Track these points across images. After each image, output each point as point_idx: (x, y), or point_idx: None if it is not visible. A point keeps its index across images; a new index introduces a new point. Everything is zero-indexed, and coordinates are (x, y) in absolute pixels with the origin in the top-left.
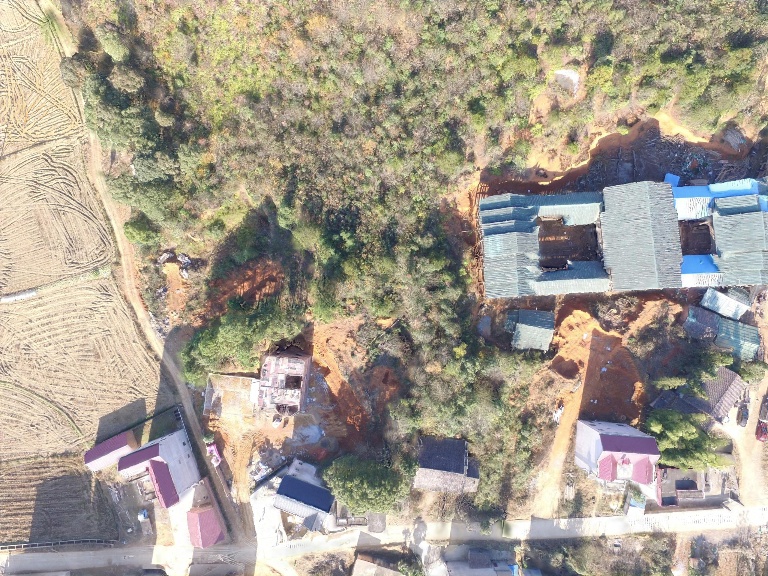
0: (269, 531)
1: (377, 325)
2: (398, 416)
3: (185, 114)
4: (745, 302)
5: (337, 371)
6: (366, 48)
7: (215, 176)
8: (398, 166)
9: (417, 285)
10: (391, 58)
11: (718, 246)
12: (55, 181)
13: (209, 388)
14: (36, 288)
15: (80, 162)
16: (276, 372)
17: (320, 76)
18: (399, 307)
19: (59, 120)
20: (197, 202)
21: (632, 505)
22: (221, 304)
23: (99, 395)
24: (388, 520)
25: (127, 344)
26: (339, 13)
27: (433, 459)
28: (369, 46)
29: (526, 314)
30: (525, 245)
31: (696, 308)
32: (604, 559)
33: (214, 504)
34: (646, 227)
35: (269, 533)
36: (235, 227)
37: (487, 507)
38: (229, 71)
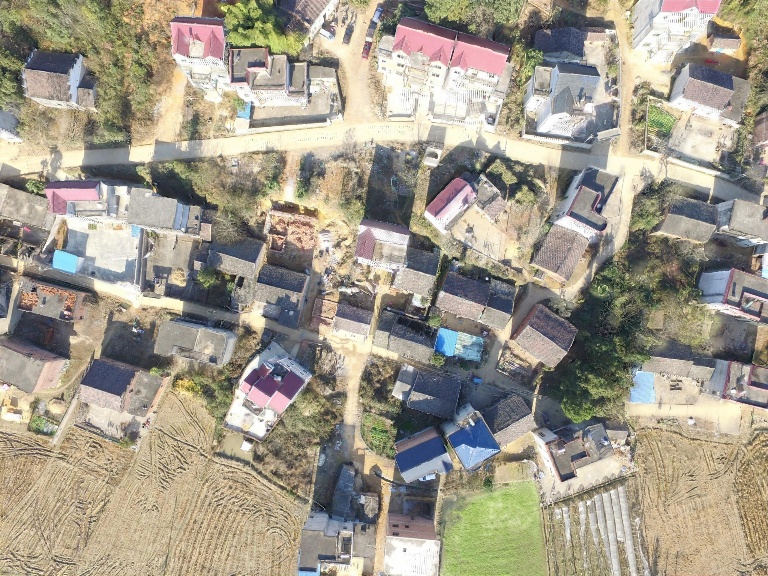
0: None
1: None
2: None
3: None
4: None
5: None
6: None
7: None
8: None
9: None
10: None
11: None
12: None
13: None
14: None
15: None
16: None
17: None
18: None
19: None
20: None
21: (237, 116)
22: None
23: None
24: (27, 151)
25: None
26: None
27: (43, 65)
28: None
29: None
30: None
31: None
32: (222, 179)
33: None
34: None
35: None
36: None
37: (106, 124)
38: None
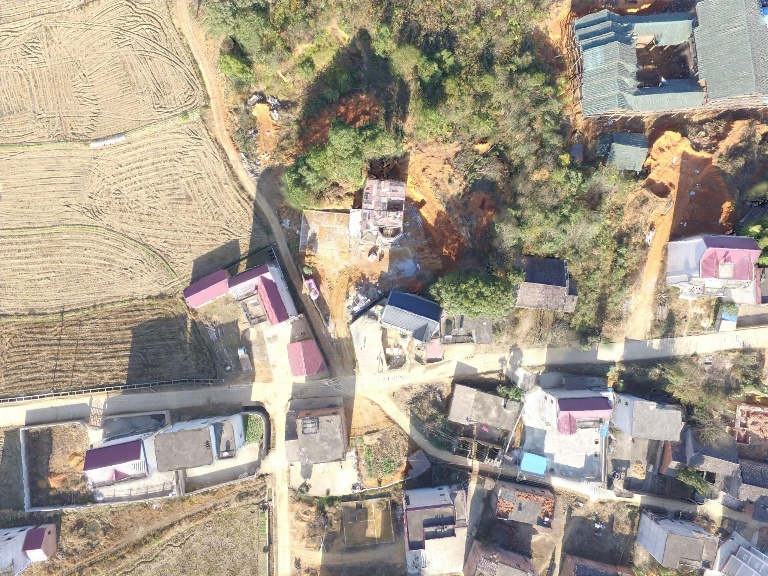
0: (371, 359)
1: (474, 151)
2: (504, 227)
3: None
4: None
5: (433, 201)
6: None
7: (311, 5)
8: None
9: (518, 101)
10: None
11: None
12: (140, 27)
13: (304, 224)
14: (125, 133)
15: (165, 8)
16: (378, 195)
17: None
18: (495, 132)
19: None
20: (292, 34)
21: (724, 319)
22: (313, 143)
23: (192, 237)
24: (484, 349)
25: (219, 187)
26: None
27: (535, 275)
28: None
29: (620, 136)
30: (625, 55)
31: None
32: (696, 377)
33: (313, 338)
34: (742, 34)
35: (371, 360)
36: (325, 67)
37: (584, 327)
38: None
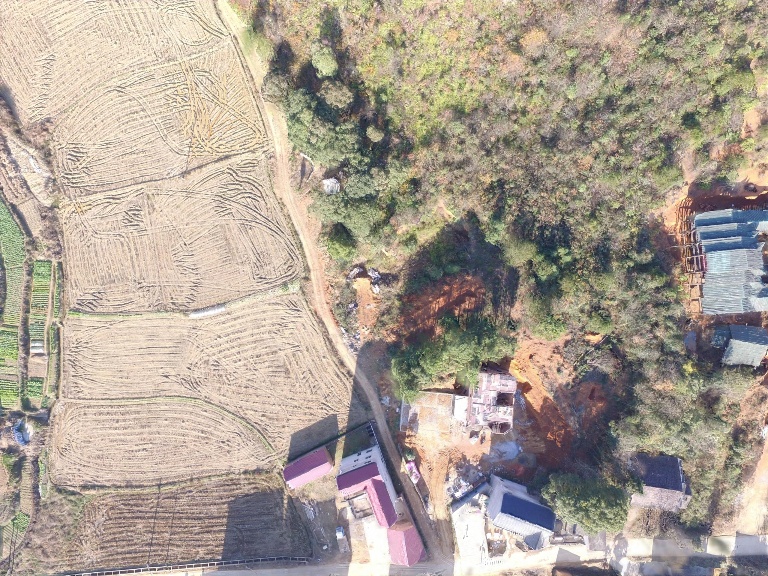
0: (473, 548)
1: (585, 341)
2: (622, 434)
3: (389, 129)
4: None
5: (539, 387)
6: (581, 63)
7: (421, 191)
8: (614, 181)
9: (637, 301)
10: (606, 73)
11: None
12: (241, 196)
13: (405, 404)
14: (225, 304)
15: (266, 176)
16: (488, 389)
17: (527, 90)
18: (607, 323)
19: (244, 134)
20: (399, 217)
21: None
22: (414, 319)
23: (290, 411)
24: None
25: (317, 360)
26: (552, 27)
27: (649, 476)
28: (587, 61)
29: (737, 330)
30: (752, 261)
31: None
32: None
33: (412, 521)
34: None
35: (473, 550)
36: (427, 242)
37: (696, 524)
38: (436, 86)
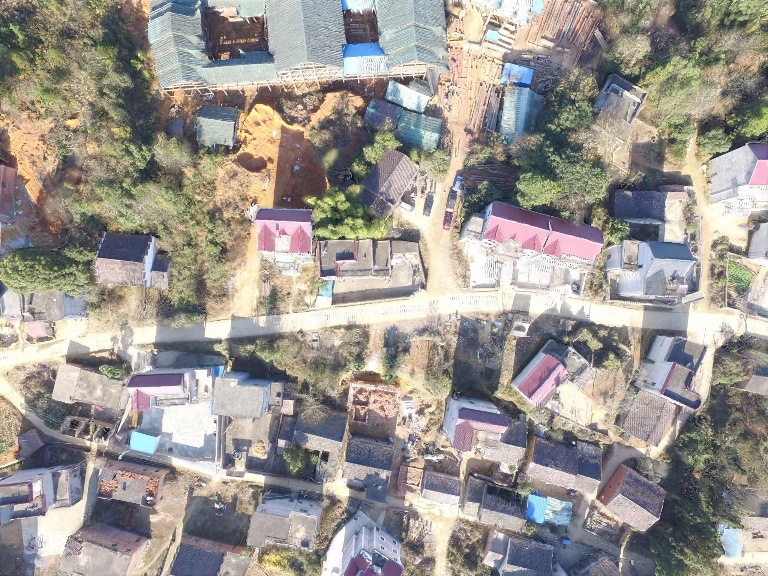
0: None
1: (65, 127)
2: (67, 202)
3: None
4: (426, 93)
5: (35, 179)
6: None
7: None
8: None
9: None
10: None
11: (380, 27)
12: None
13: None
14: None
15: None
16: None
17: None
18: None
19: None
20: None
21: (319, 294)
22: None
23: None
24: (96, 327)
25: None
26: None
27: (115, 251)
28: None
29: (209, 110)
30: (183, 26)
31: (378, 101)
32: (303, 354)
33: None
34: (297, 3)
35: None
36: None
37: (181, 304)
38: None
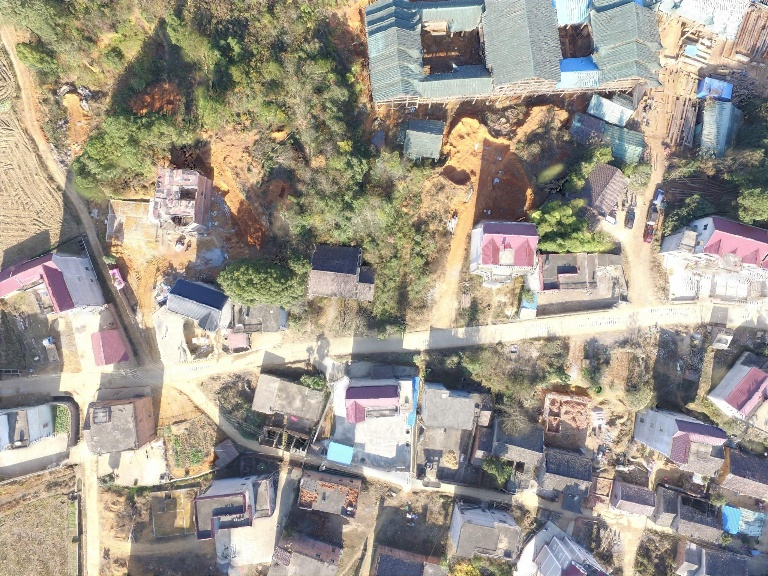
0: (172, 348)
1: (271, 139)
2: (287, 215)
3: None
4: (629, 107)
5: (236, 190)
6: None
7: None
8: None
9: (304, 89)
10: None
11: (596, 42)
12: None
13: (111, 214)
14: None
15: None
16: (170, 184)
17: None
18: (292, 120)
19: None
20: (90, 24)
21: (524, 307)
22: None
23: (3, 228)
24: (292, 338)
25: (30, 177)
26: None
27: (327, 263)
28: None
29: (416, 123)
30: (406, 41)
31: (582, 114)
32: (501, 366)
33: (119, 328)
34: (522, 18)
35: (172, 350)
36: (134, 57)
37: (385, 315)
38: None
